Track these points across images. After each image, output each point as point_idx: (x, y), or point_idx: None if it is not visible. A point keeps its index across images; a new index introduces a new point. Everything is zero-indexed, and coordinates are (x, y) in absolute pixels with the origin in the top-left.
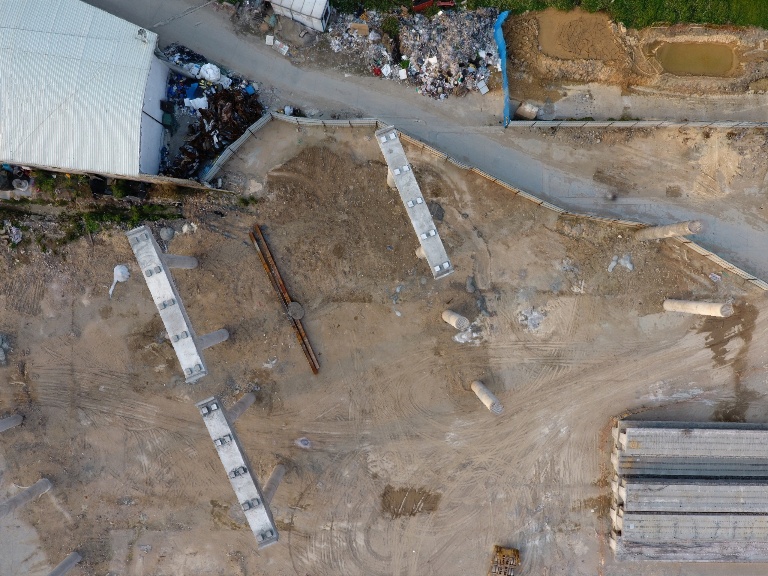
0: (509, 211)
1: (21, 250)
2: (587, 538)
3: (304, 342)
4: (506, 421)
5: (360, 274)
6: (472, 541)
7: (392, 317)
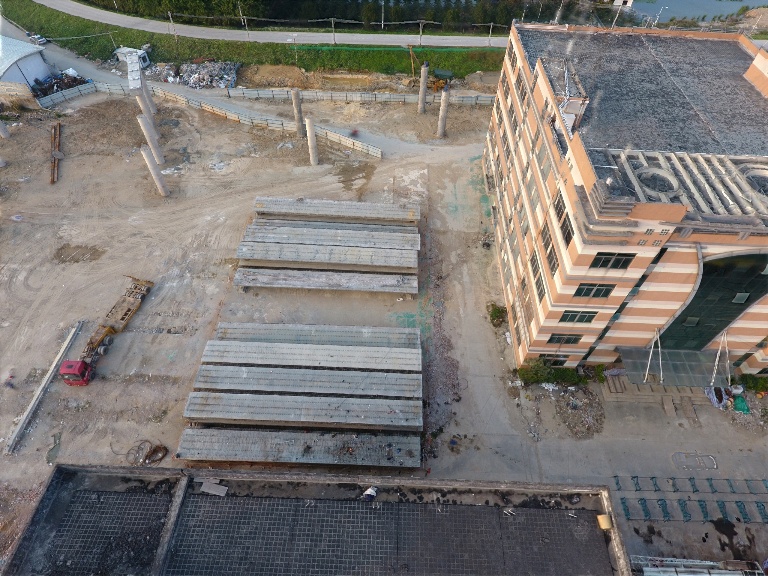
0: (220, 124)
1: None
2: (220, 283)
3: (54, 169)
4: (180, 212)
5: (112, 144)
6: (118, 281)
7: (123, 162)
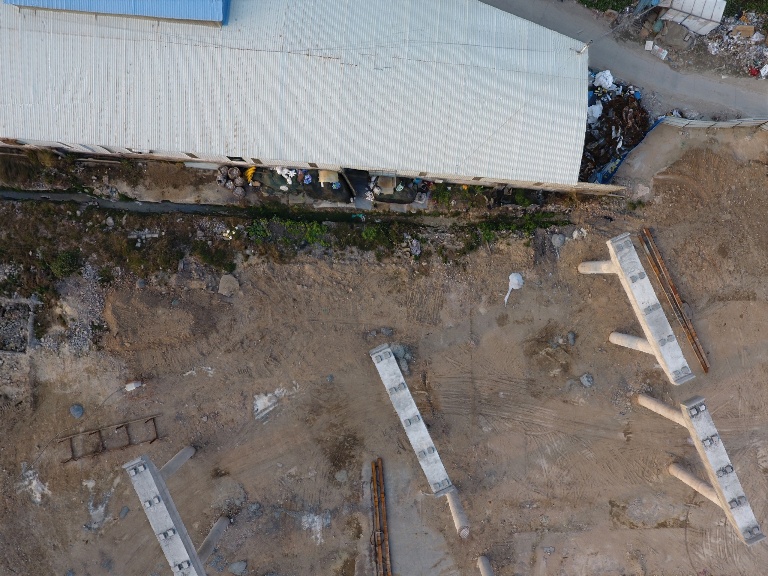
0: None
1: (423, 262)
2: None
3: (695, 342)
4: None
5: (744, 273)
6: None
7: None
